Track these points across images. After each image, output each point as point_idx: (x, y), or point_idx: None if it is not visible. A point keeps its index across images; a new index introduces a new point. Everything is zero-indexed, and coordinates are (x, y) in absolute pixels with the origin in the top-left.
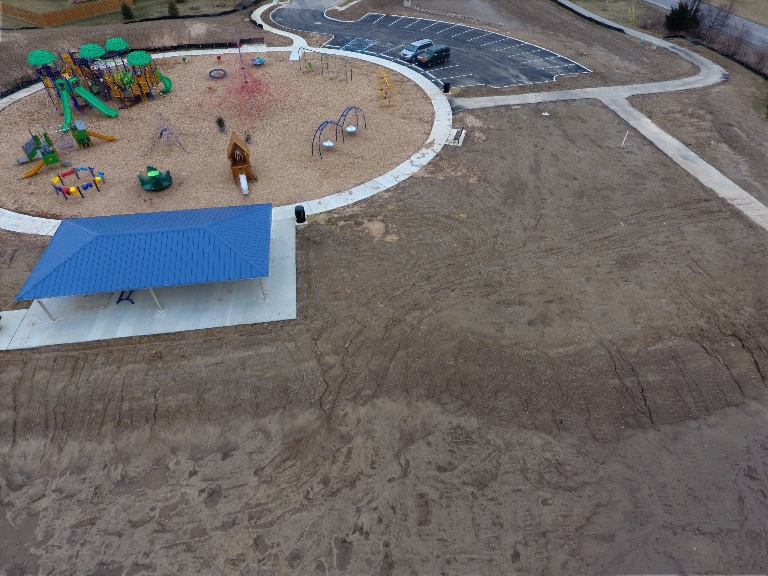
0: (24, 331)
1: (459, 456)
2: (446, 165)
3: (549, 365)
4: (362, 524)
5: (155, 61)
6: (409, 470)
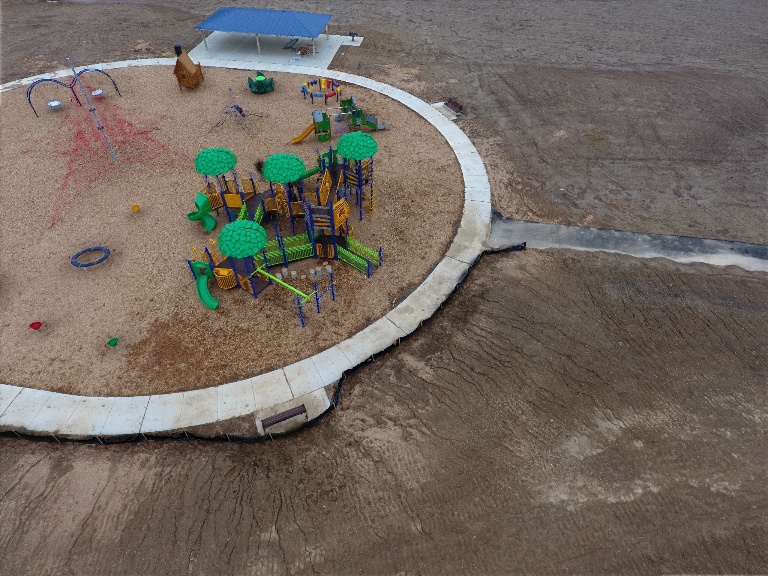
0: (341, 39)
1: (197, 6)
2: (34, 69)
3: (140, 5)
4: (236, 4)
5: (180, 371)
6: (214, 7)
